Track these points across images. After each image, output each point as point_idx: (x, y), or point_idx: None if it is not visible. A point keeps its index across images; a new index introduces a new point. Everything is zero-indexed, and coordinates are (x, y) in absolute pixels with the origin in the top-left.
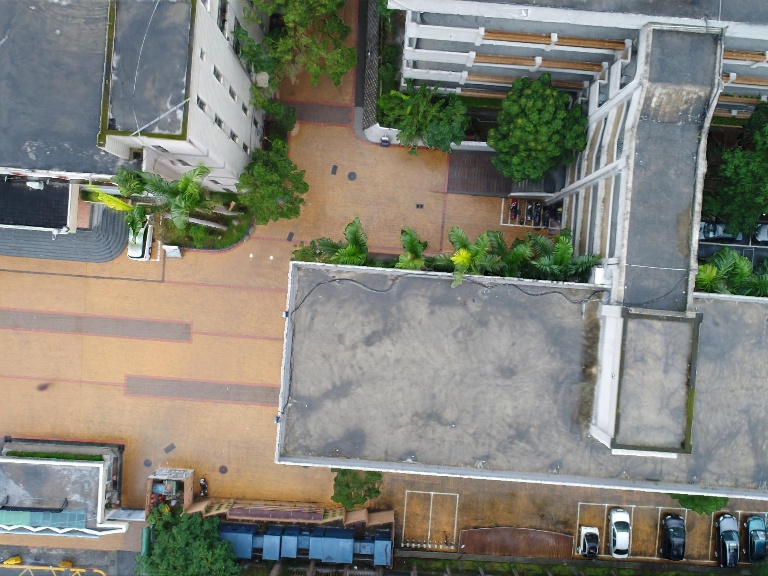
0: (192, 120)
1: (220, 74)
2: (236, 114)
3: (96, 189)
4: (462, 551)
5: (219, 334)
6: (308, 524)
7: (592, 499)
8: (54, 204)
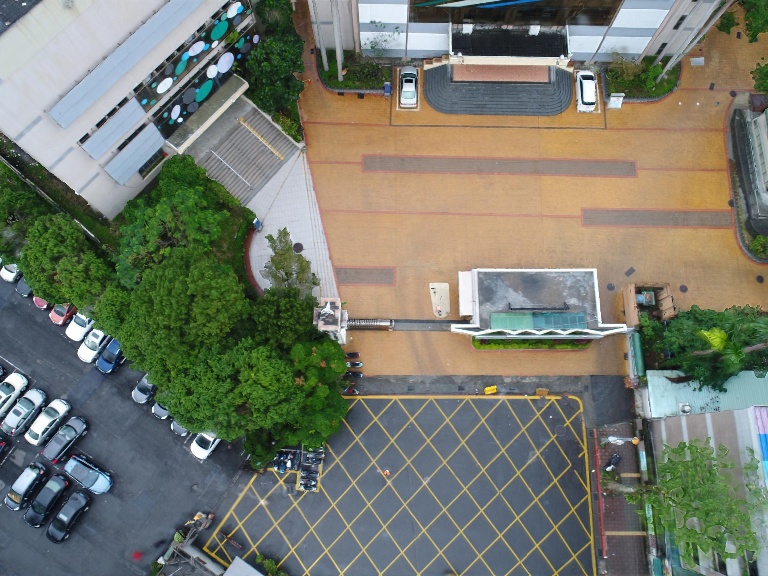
0: None
1: None
2: None
3: (575, 37)
4: None
5: (661, 169)
6: None
7: None
8: (547, 45)
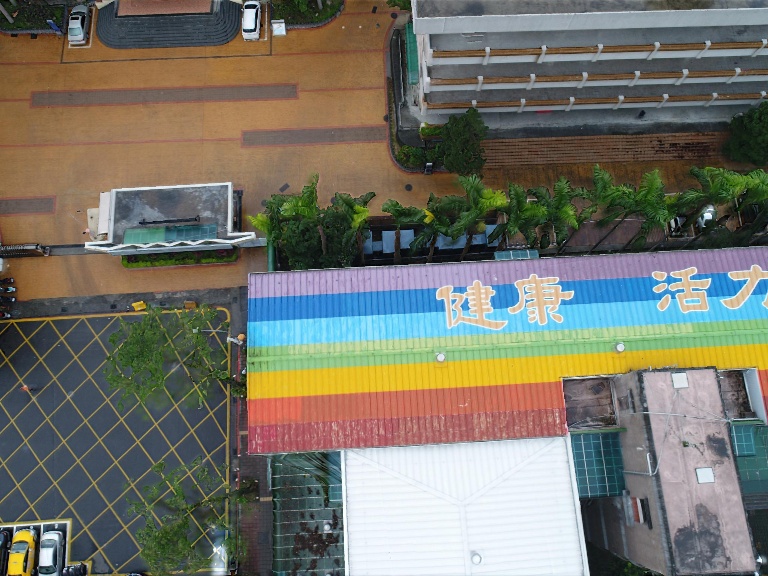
0: None
1: None
2: None
3: None
4: (565, 245)
5: (321, 90)
6: None
7: (671, 190)
8: None
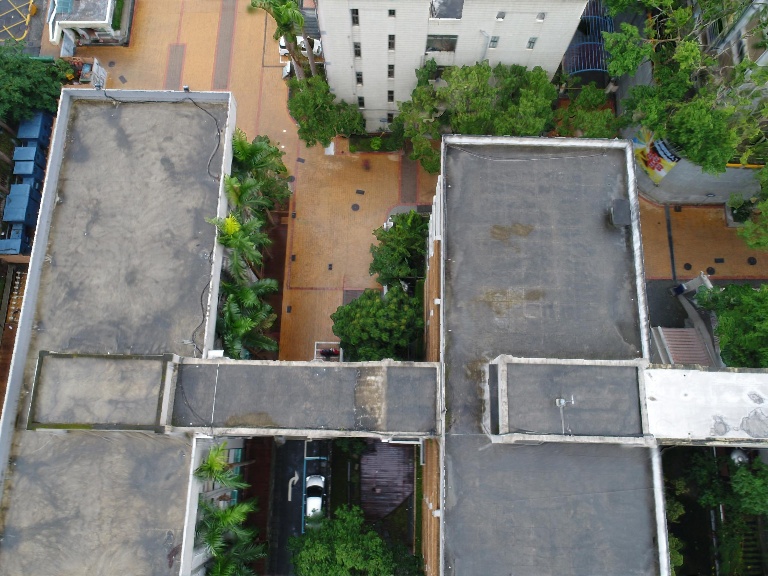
0: (335, 3)
1: (395, 47)
2: (379, 80)
3: None
4: (6, 327)
5: None
6: None
7: None
8: None
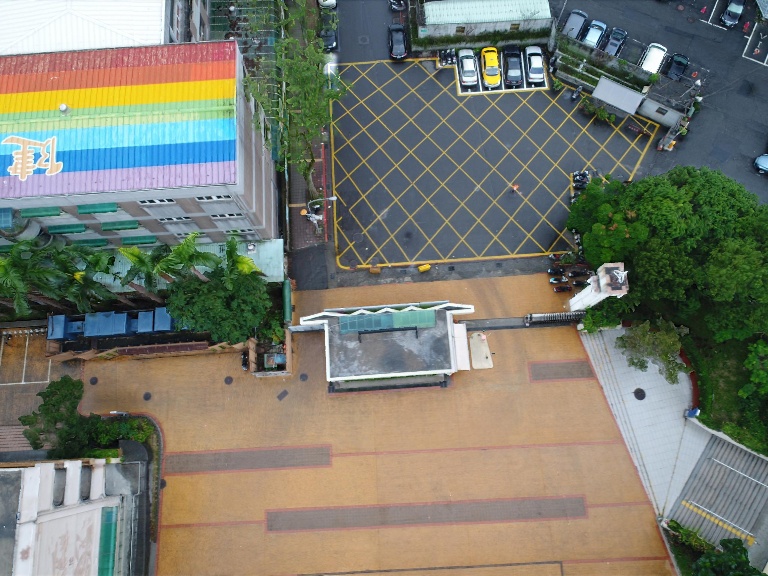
0: None
1: None
2: None
3: None
4: None
5: (237, 524)
6: (143, 338)
7: None
8: None
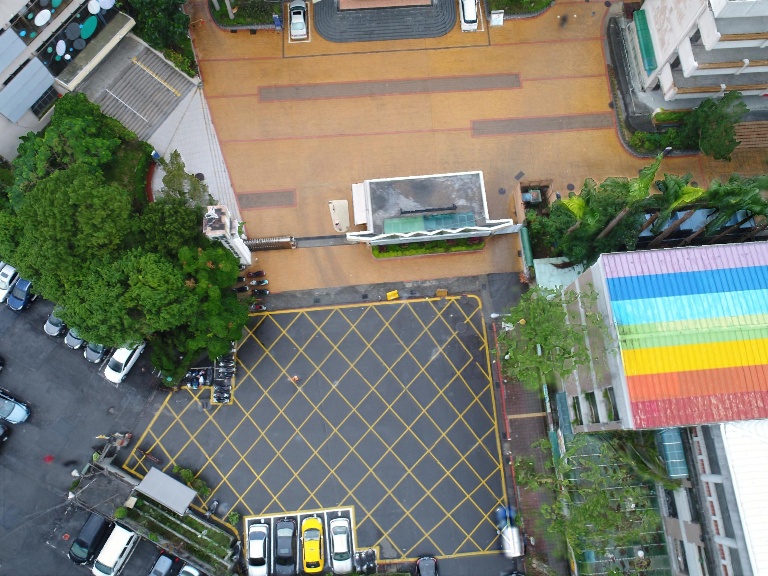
0: None
1: None
2: None
3: None
4: None
5: (544, 79)
6: None
7: None
8: None
